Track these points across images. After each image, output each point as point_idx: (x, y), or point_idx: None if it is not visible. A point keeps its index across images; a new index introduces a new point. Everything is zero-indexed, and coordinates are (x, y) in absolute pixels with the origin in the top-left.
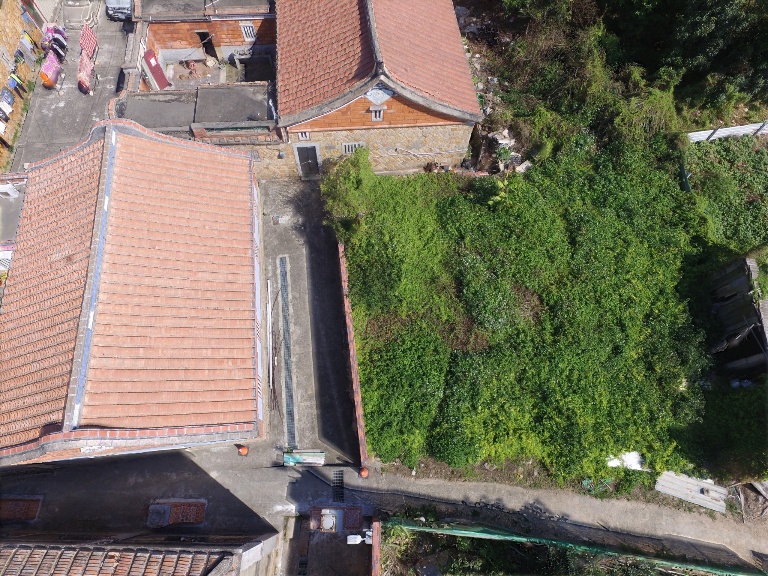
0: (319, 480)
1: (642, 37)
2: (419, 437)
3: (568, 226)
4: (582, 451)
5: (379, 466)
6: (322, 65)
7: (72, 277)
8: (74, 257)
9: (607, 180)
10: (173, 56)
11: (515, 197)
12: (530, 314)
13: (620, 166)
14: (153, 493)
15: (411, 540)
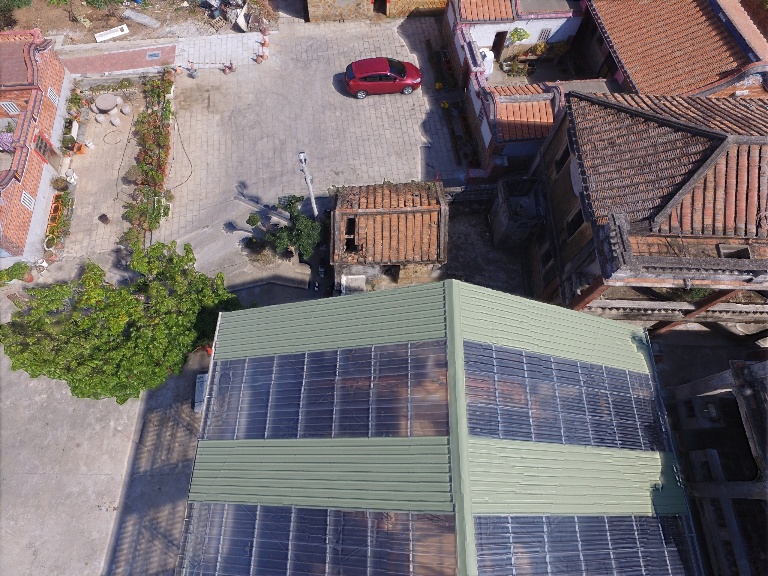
0: None
1: None
2: None
3: None
4: None
5: None
6: None
7: (678, 6)
8: None
9: None
10: None
11: None
12: None
13: None
14: None
15: None
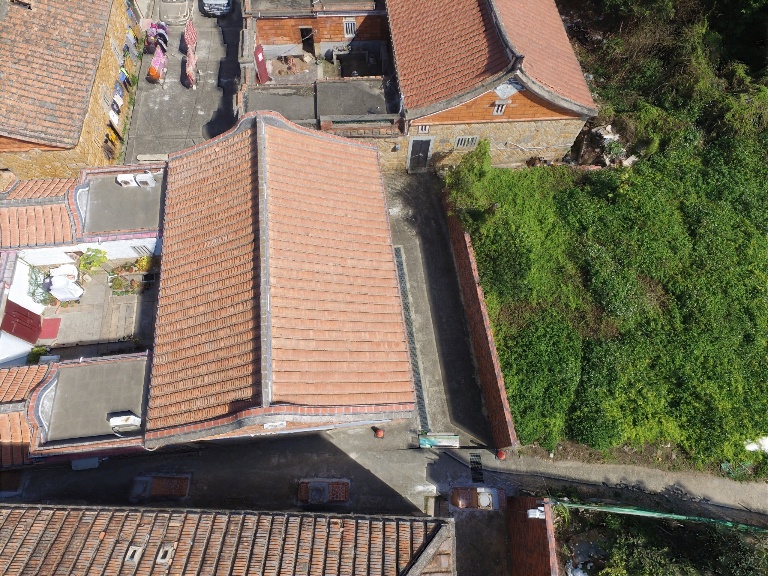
0: (457, 462)
1: (743, 35)
2: (559, 420)
3: (685, 218)
4: (723, 434)
5: (516, 448)
6: (445, 60)
7: (236, 262)
8: (235, 243)
9: (721, 174)
10: (273, 52)
11: (634, 190)
12: (656, 303)
13: (732, 161)
14: (297, 473)
15: (562, 518)
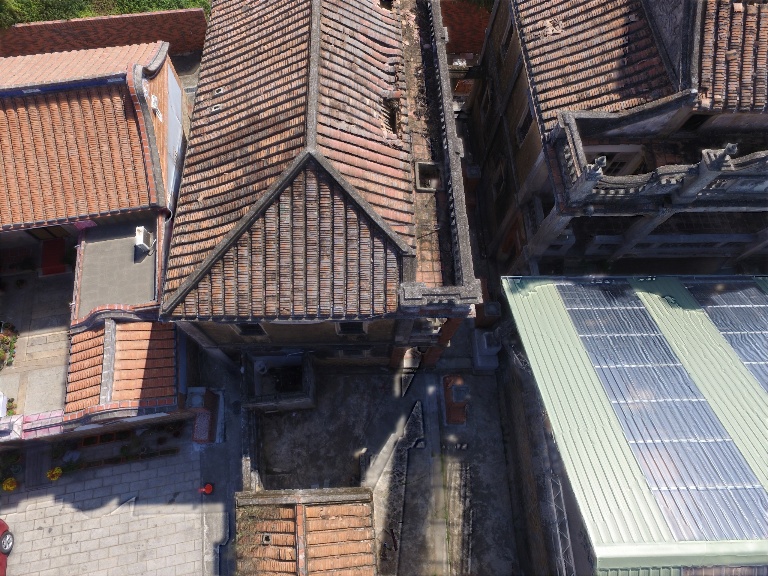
0: None
1: None
2: None
3: None
4: None
5: None
6: None
7: None
8: None
9: None
10: None
11: None
12: None
13: None
14: None
15: None
